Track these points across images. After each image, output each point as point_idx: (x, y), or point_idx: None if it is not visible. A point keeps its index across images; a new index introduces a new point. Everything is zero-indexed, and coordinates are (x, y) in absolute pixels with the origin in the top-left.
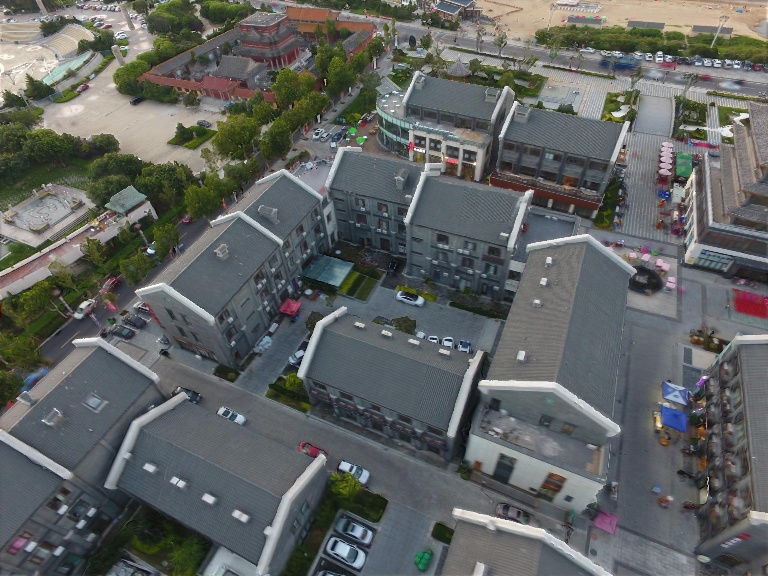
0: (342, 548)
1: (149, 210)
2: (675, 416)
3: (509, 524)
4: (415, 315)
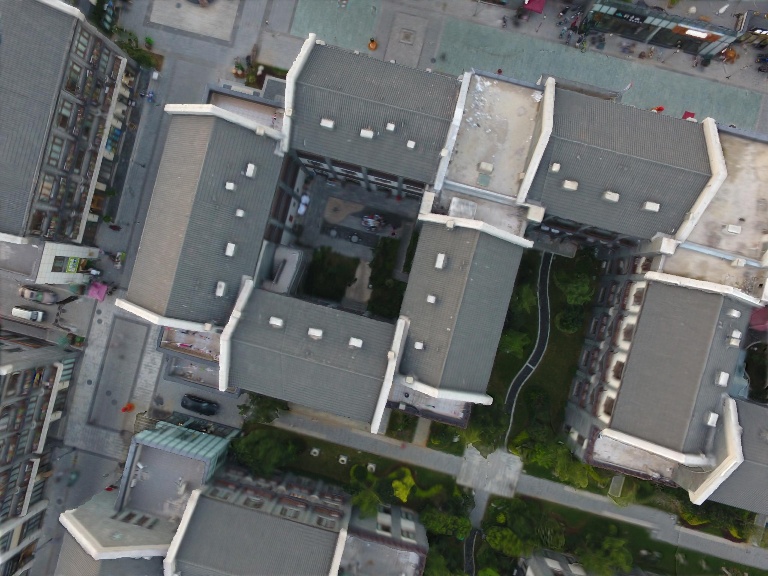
0: None
1: None
2: None
3: None
4: None
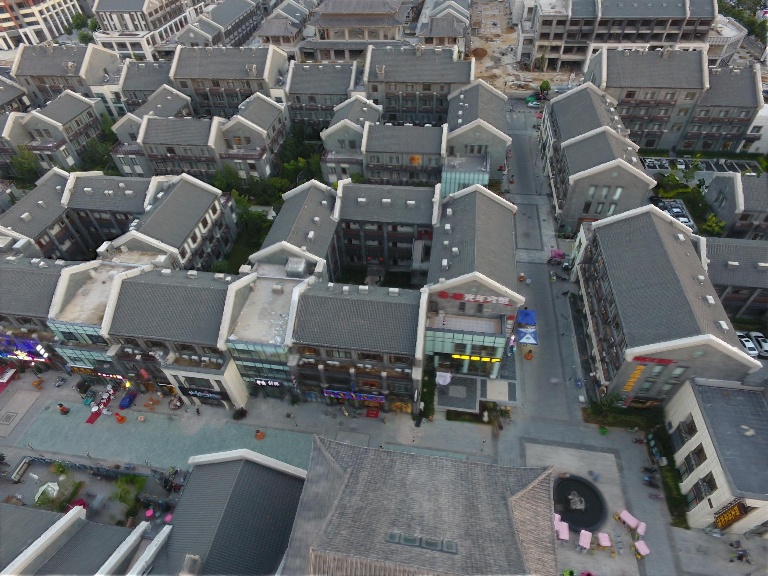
0: (684, 219)
1: None
2: (528, 314)
3: (633, 167)
4: None
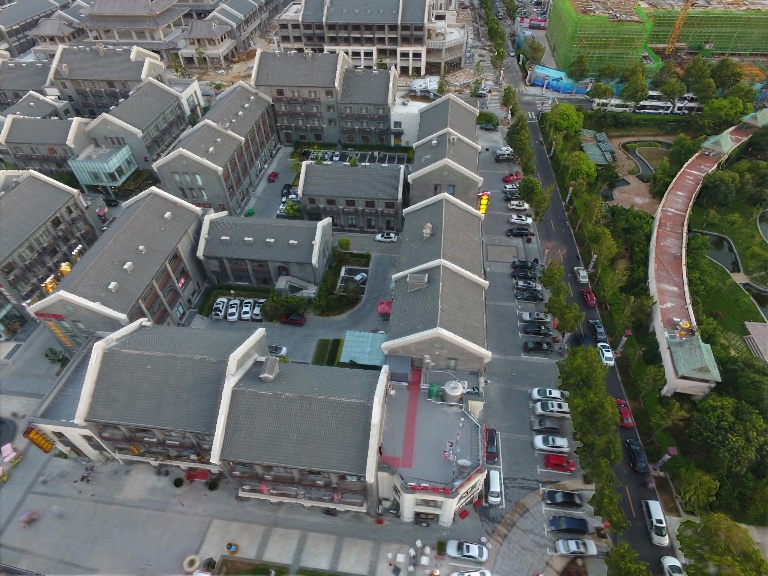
0: None
1: (641, 351)
2: None
3: (195, 155)
4: (266, 339)
